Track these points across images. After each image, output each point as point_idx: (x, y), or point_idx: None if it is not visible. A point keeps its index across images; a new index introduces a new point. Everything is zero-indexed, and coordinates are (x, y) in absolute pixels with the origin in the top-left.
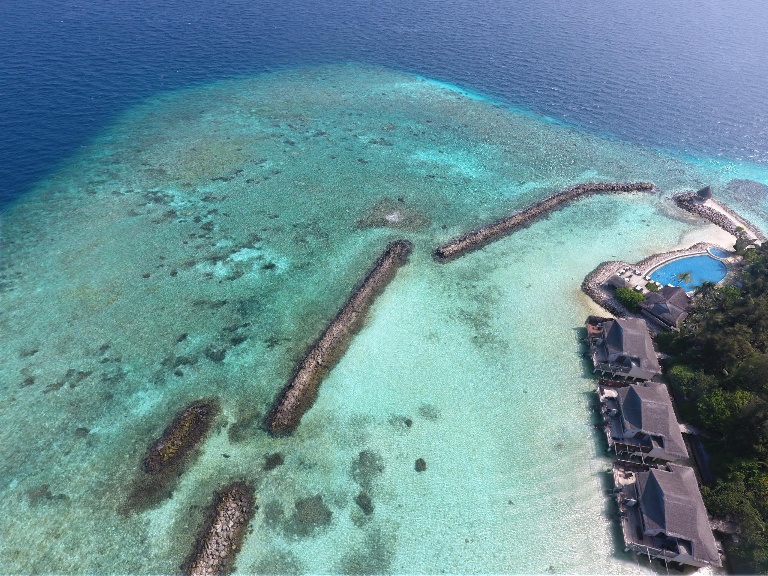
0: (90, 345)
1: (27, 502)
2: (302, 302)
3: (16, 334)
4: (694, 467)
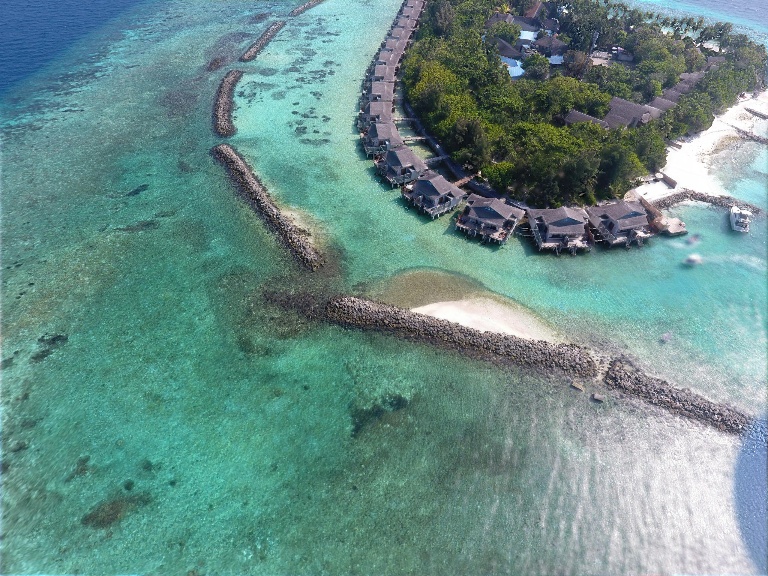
0: (223, 6)
1: (219, 23)
2: (298, 0)
3: (196, 5)
4: None
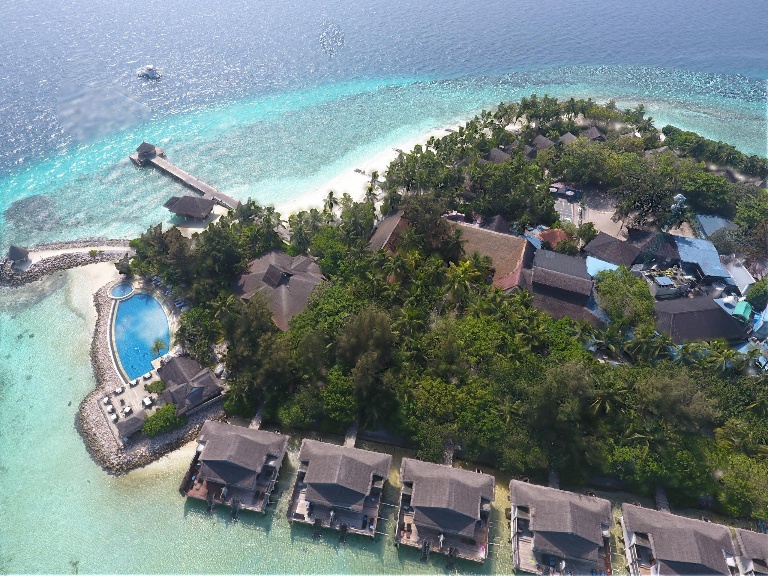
0: None
1: None
2: None
3: None
4: (387, 448)
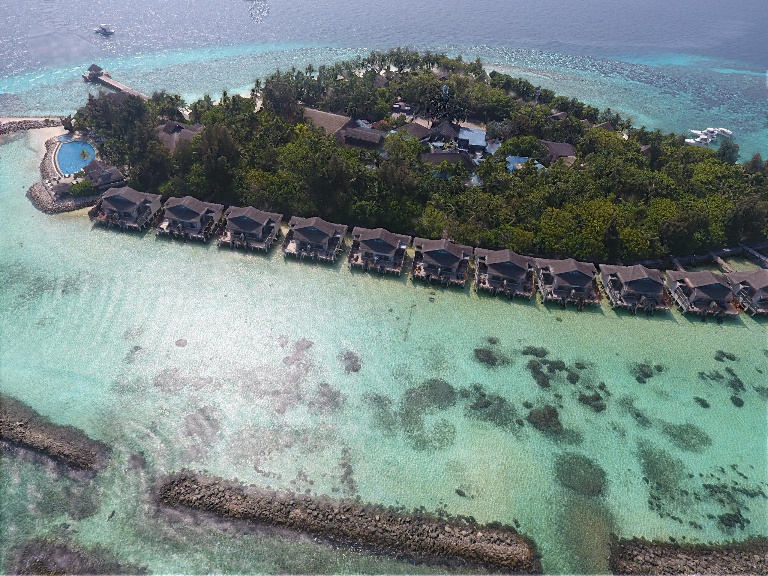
0: None
1: None
2: None
3: None
4: None
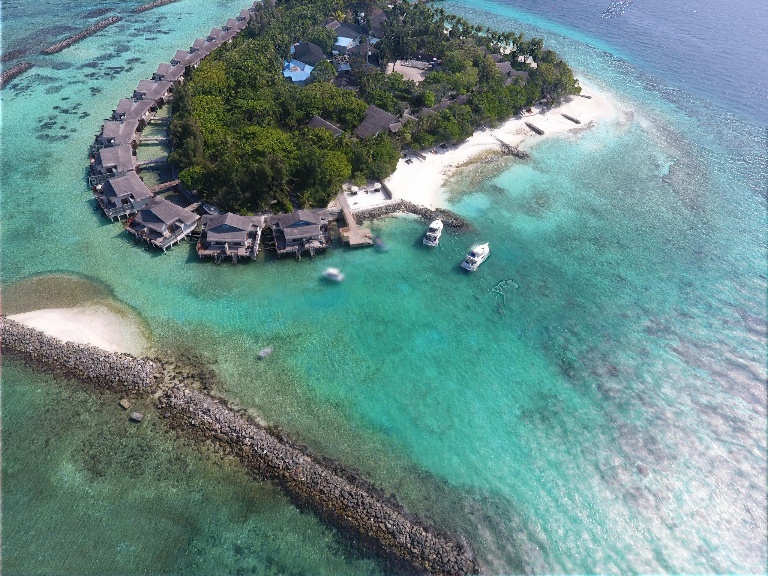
0: None
1: None
2: None
3: None
4: None
